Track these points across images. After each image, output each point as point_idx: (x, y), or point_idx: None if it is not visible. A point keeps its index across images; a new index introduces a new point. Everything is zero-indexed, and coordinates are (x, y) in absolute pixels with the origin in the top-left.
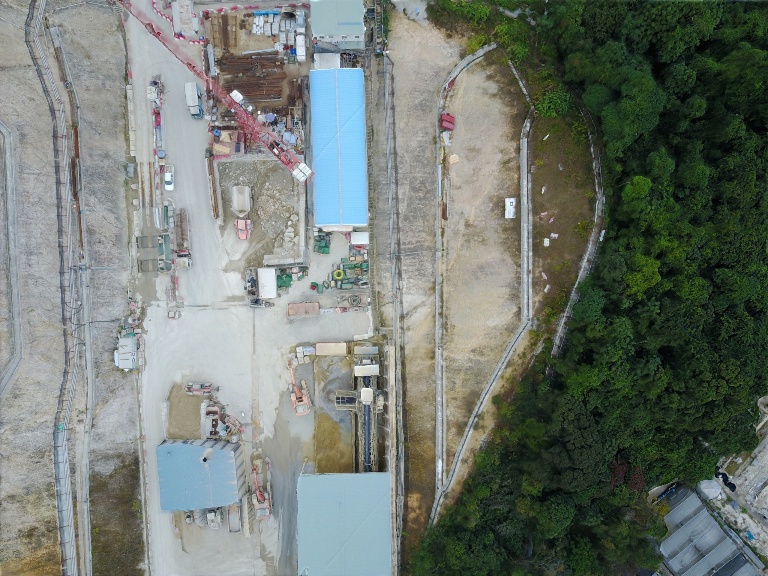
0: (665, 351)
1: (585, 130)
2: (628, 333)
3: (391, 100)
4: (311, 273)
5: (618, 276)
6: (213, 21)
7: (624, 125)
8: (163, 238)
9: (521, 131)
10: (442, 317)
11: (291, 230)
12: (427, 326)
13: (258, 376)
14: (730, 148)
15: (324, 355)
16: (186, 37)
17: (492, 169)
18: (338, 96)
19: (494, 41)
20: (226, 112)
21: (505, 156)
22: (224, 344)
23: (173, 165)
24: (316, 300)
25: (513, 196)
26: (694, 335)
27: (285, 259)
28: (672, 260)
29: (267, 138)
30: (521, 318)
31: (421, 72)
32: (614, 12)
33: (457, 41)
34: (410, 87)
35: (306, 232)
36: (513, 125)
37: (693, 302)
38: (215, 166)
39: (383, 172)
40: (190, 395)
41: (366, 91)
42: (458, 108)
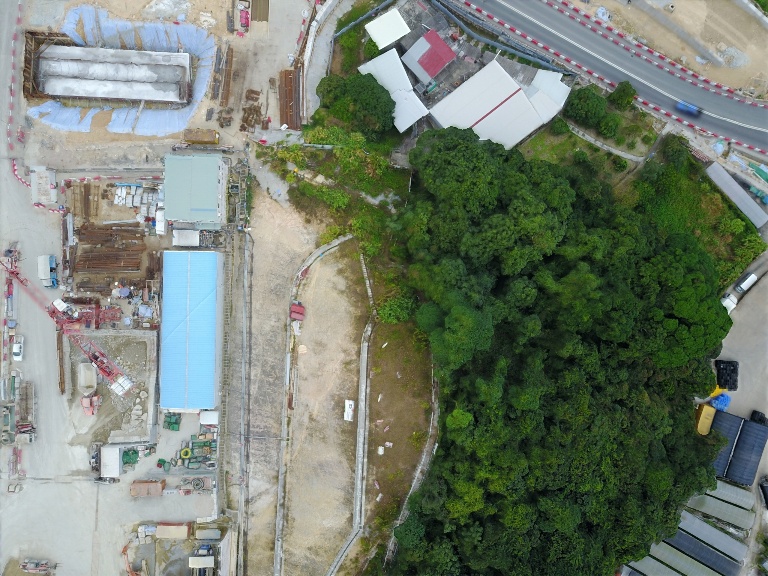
0: (494, 568)
1: (426, 338)
2: (447, 561)
3: (250, 278)
4: (159, 449)
5: (436, 506)
6: (75, 190)
7: (449, 353)
8: (9, 409)
9: (362, 335)
10: (284, 508)
11: (139, 408)
12: (269, 515)
13: (99, 553)
14: (573, 359)
15: (165, 537)
16: (46, 205)
17: (335, 367)
18: (190, 279)
19: (349, 232)
20: (82, 283)
21: (347, 357)
22: (65, 519)
23: (23, 335)
24: (162, 478)
25: (352, 399)
26: (521, 557)
27: (131, 437)
28: (493, 490)
29: (89, 348)
30: (353, 525)
31: (278, 255)
32: (456, 226)
33: (315, 227)
34: (267, 269)
35: (157, 407)
36: (356, 327)
37: (515, 530)
38: (65, 340)
39: (239, 350)
40: (26, 572)
41: (226, 267)
42: (309, 298)
